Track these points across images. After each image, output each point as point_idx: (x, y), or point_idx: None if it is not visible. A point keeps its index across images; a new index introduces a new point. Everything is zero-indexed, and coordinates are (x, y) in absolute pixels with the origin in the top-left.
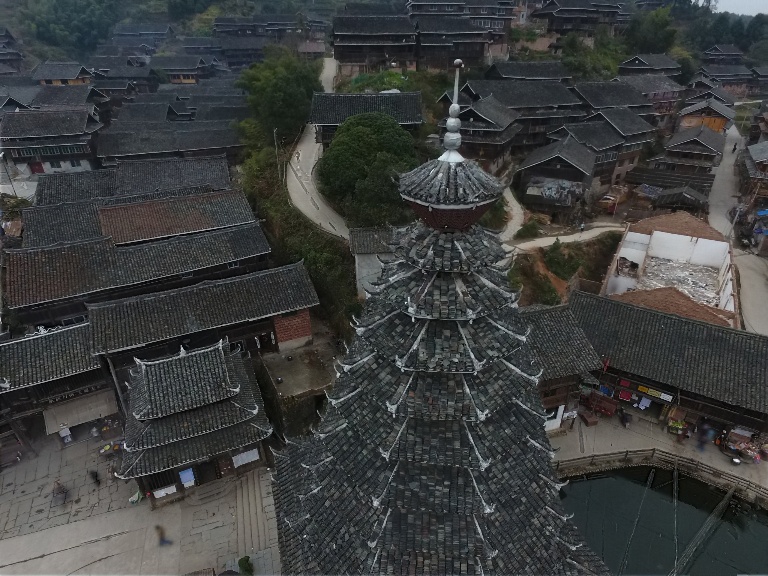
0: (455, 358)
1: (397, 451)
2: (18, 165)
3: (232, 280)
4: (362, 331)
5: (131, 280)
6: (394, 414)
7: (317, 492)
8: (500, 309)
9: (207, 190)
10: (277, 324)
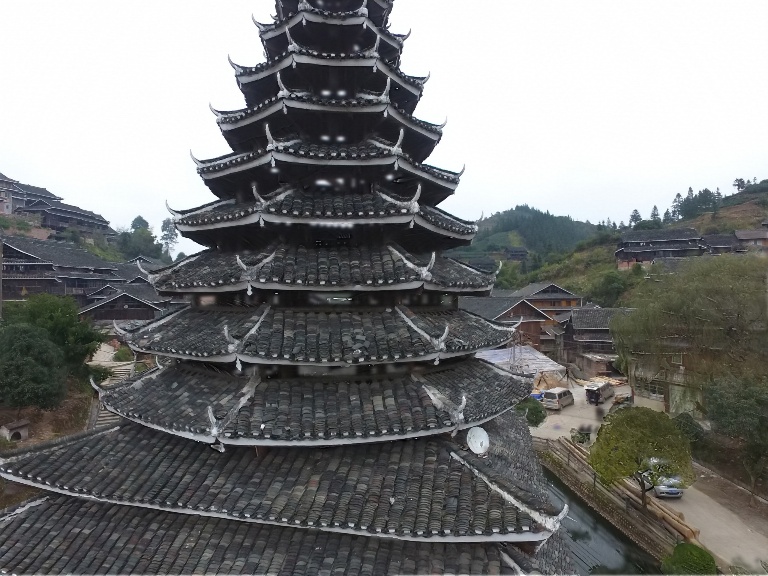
0: None
1: None
2: None
3: None
4: (297, 48)
5: None
6: (386, 111)
7: (256, 333)
8: None
9: None
10: None
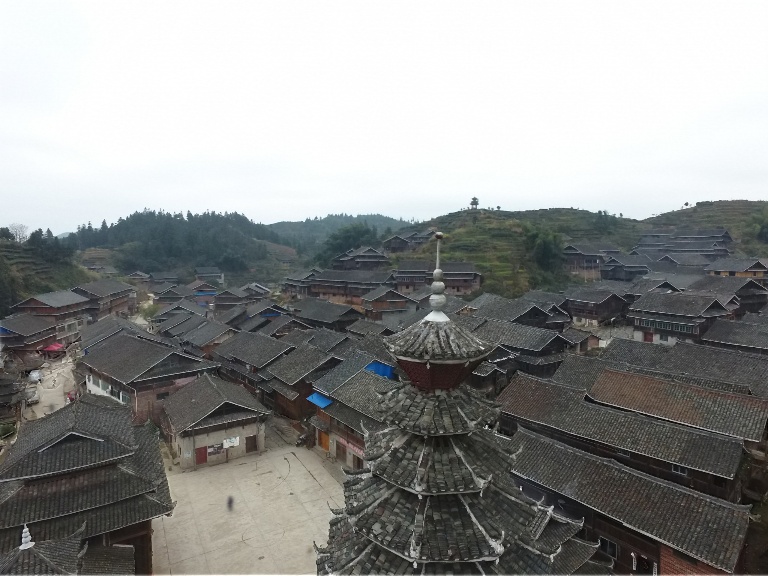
0: (357, 503)
1: (323, 561)
2: (636, 332)
3: (641, 475)
4: None
5: (570, 429)
6: None
7: None
8: (464, 525)
9: (741, 391)
10: (664, 557)
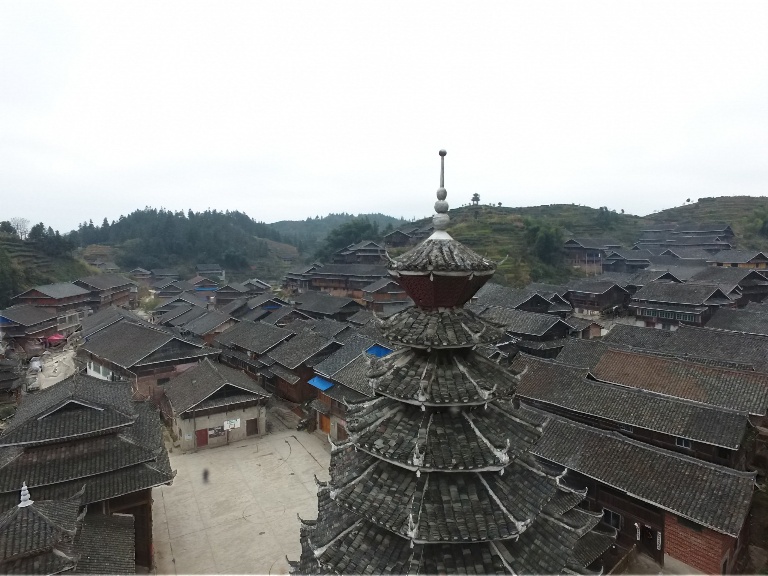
0: None
1: (324, 493)
2: (638, 321)
3: (644, 446)
4: None
5: (572, 406)
6: None
7: None
8: (468, 438)
9: None
10: (668, 526)
